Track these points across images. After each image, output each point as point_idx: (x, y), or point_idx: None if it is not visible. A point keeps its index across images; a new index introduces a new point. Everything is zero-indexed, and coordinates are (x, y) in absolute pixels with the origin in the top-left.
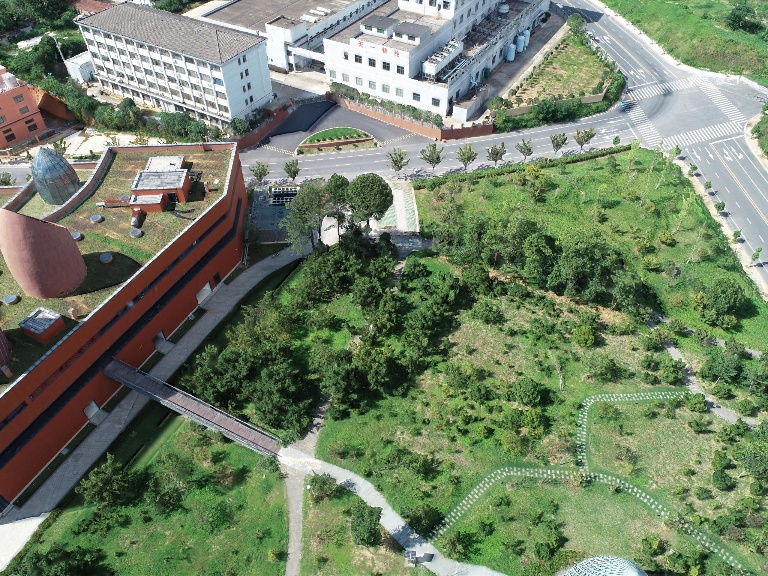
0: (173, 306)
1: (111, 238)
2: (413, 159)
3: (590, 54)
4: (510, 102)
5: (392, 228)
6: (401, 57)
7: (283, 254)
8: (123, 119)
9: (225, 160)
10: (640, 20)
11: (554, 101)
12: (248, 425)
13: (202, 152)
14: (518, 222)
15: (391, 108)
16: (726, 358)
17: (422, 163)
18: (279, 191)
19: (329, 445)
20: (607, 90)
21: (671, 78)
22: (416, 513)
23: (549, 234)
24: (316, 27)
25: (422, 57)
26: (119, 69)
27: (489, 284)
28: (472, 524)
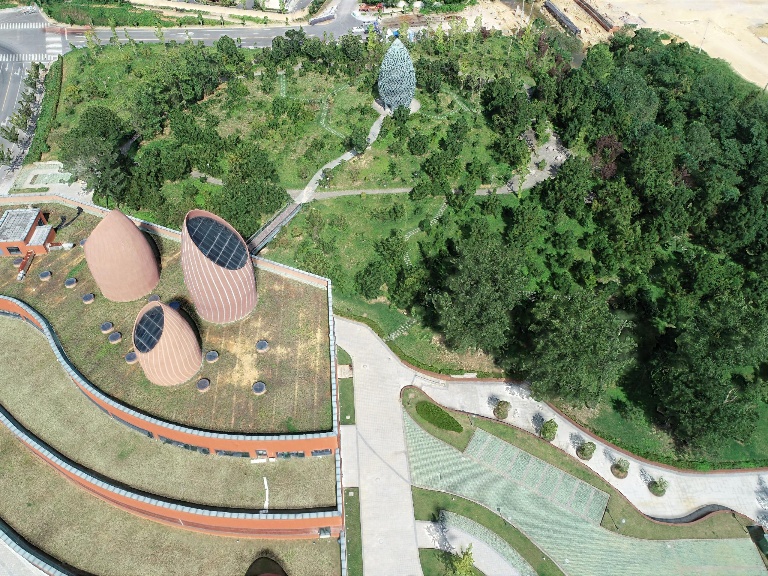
0: None
1: None
2: None
3: None
4: None
5: None
6: None
7: None
8: None
9: None
10: None
11: None
12: None
13: None
14: None
15: None
16: (273, 50)
17: None
18: None
19: None
20: None
21: None
22: (348, 137)
23: None
24: None
25: None
26: None
27: None
28: (350, 132)
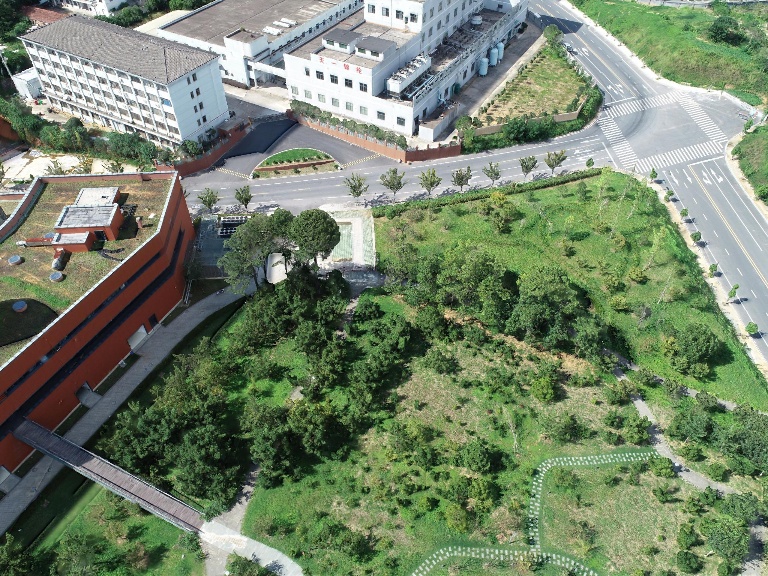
0: (99, 355)
1: (29, 283)
2: (375, 183)
3: (567, 68)
4: (479, 121)
5: (347, 261)
6: (363, 74)
7: (228, 291)
8: (69, 140)
9: (164, 191)
10: (620, 31)
11: (526, 120)
12: (171, 494)
13: (140, 182)
14: (472, 264)
15: (353, 128)
16: (695, 418)
17: (384, 187)
18: (228, 220)
19: (255, 521)
20: (582, 107)
21: (650, 93)
22: None
23: (512, 270)
24: (279, 40)
25: (387, 73)
26: (66, 86)
27: (445, 327)
28: None
